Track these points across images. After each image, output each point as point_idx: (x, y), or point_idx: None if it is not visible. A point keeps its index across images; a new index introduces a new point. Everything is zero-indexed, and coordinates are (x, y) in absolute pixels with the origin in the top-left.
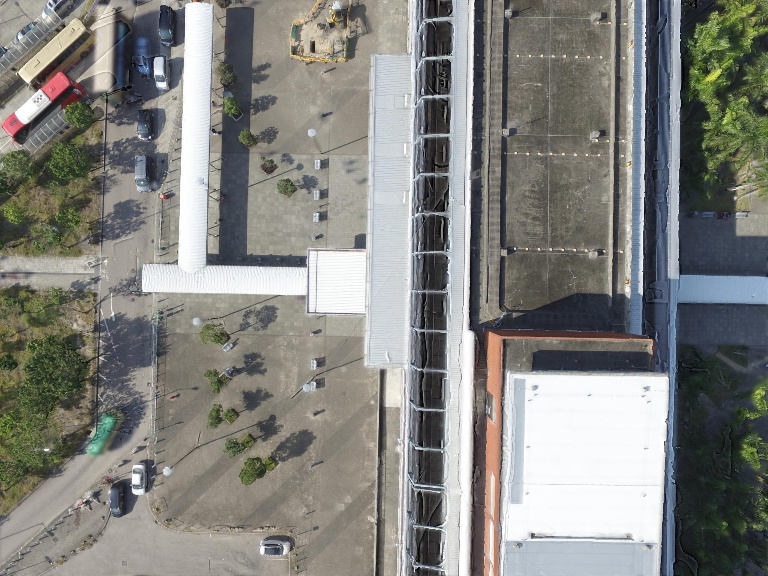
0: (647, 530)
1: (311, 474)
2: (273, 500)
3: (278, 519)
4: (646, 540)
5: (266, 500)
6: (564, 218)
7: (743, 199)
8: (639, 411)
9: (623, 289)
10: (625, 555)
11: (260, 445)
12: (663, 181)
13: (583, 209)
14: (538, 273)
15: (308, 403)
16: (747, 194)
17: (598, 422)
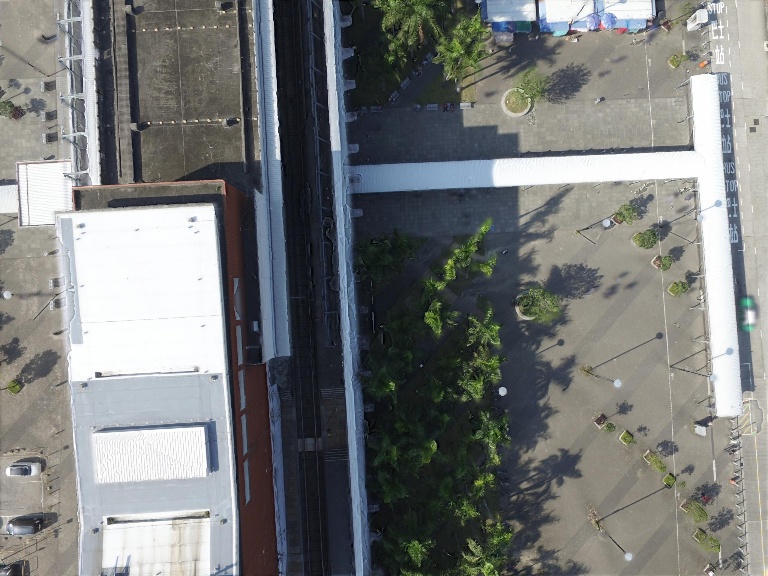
0: (210, 360)
1: (58, 394)
2: (22, 422)
3: (28, 441)
4: (211, 371)
5: (15, 423)
6: (197, 90)
7: (468, 90)
8: (187, 242)
9: (259, 155)
10: (191, 387)
11: (5, 369)
12: (365, 71)
13: (215, 80)
14: (174, 146)
15: (50, 323)
16: (471, 85)
17: (148, 256)
